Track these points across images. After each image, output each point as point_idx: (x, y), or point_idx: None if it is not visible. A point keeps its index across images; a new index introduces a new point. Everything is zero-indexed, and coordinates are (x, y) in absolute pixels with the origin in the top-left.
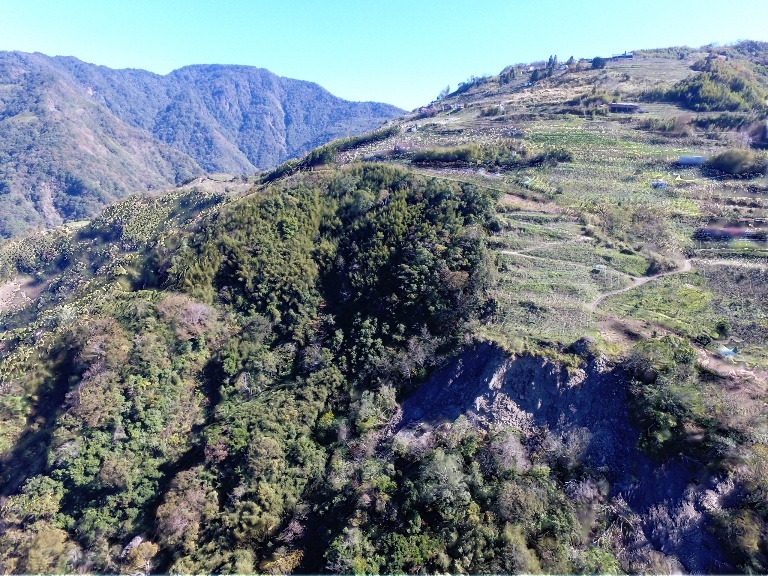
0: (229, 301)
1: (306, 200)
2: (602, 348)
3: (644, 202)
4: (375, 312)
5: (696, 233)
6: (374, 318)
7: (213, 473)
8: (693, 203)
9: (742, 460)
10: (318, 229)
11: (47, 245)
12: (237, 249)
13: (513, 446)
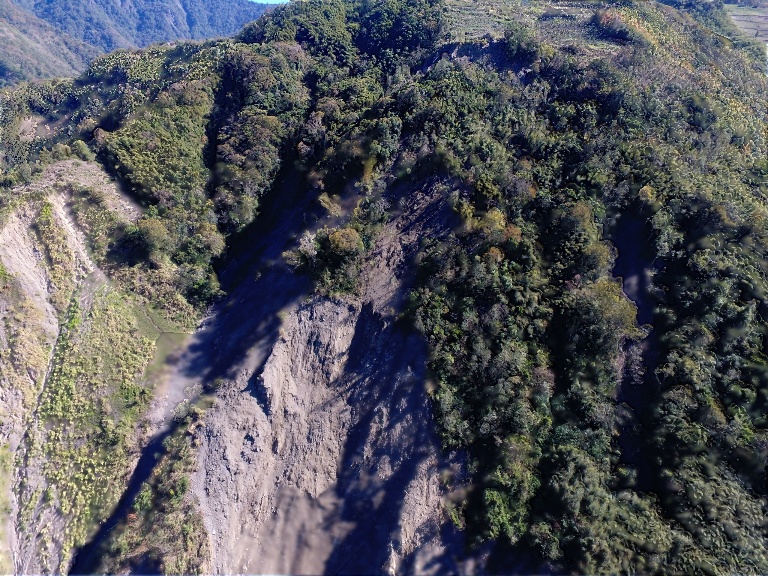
0: (307, 49)
1: (335, 1)
2: (495, 34)
3: (517, 3)
4: (391, 46)
5: (539, 15)
6: (391, 48)
7: (336, 97)
8: (540, 5)
9: (540, 59)
10: (346, 17)
11: (50, 90)
12: (305, 22)
13: (464, 58)
